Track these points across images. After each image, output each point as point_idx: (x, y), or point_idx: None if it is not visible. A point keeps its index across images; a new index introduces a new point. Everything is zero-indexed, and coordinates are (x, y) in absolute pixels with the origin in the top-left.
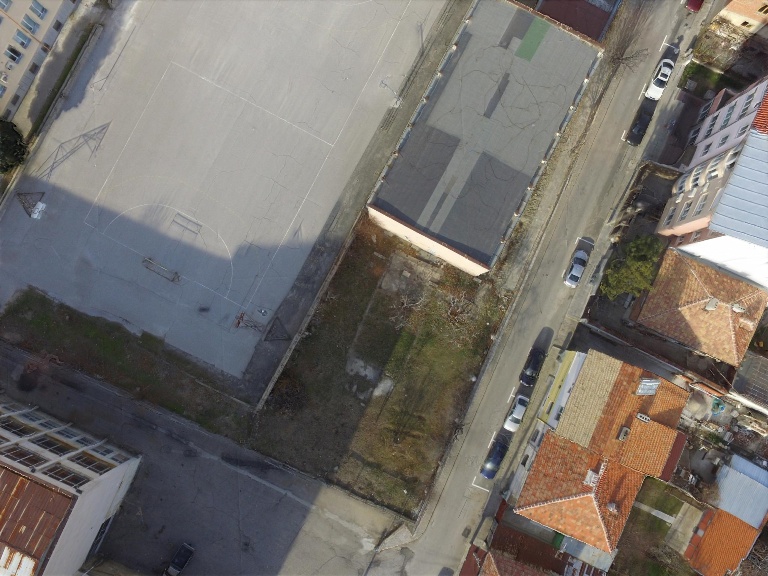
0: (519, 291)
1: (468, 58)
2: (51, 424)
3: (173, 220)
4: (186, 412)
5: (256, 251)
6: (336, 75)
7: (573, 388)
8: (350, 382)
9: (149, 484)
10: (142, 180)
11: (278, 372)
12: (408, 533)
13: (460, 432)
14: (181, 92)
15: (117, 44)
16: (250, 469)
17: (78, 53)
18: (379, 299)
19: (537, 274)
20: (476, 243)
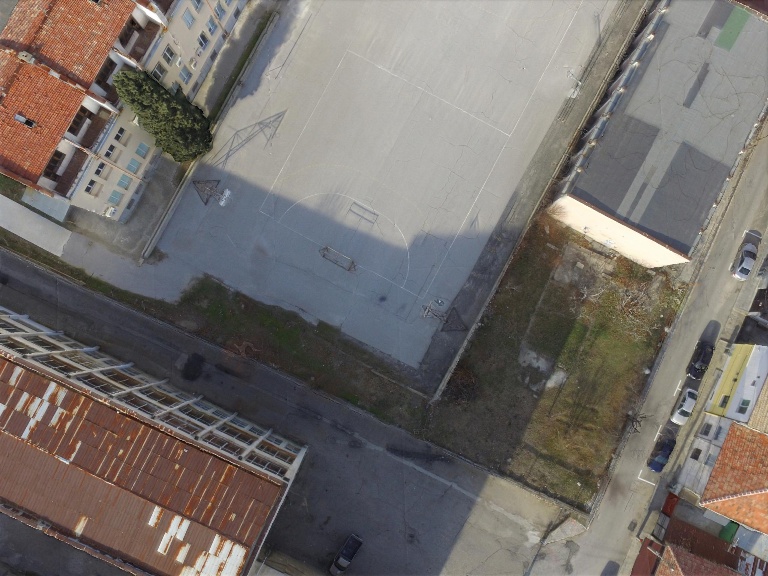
0: (694, 283)
1: (666, 48)
2: (220, 413)
3: (350, 209)
4: (360, 402)
5: (433, 241)
6: (513, 65)
7: (765, 381)
8: (523, 374)
9: (314, 475)
10: (318, 169)
11: (455, 363)
12: (574, 526)
13: (638, 424)
14: (357, 81)
15: (293, 32)
16: (415, 460)
17: (256, 41)
18: (552, 290)
19: (704, 267)
20: (676, 234)
